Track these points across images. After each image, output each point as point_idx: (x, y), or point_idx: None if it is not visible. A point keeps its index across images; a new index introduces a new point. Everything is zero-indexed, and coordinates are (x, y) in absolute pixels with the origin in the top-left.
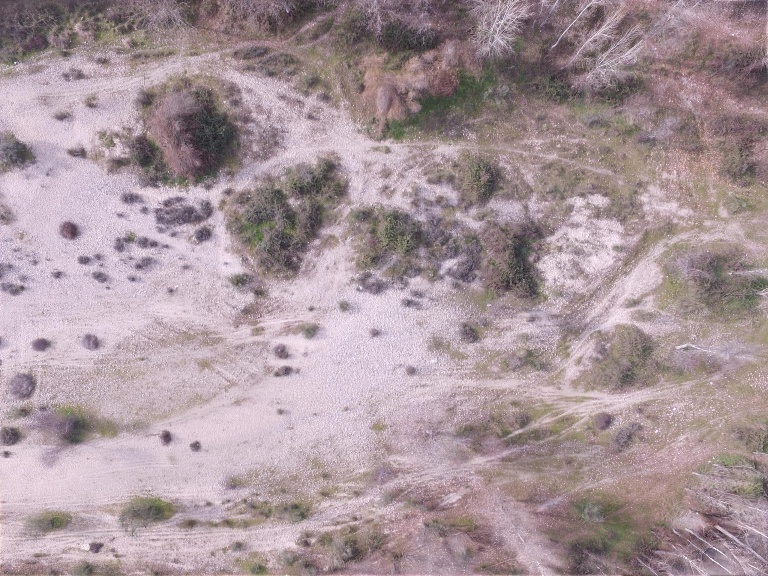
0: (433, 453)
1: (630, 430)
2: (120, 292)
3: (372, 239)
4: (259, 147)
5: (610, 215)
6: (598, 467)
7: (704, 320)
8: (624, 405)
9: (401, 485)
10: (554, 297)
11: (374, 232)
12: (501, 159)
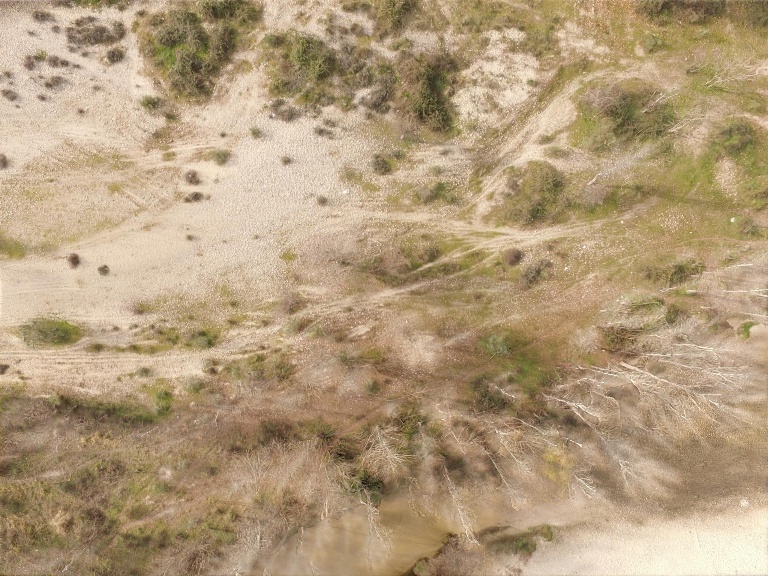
0: (342, 284)
1: (539, 266)
2: (30, 111)
3: (284, 63)
4: None
5: (526, 49)
6: (507, 303)
7: (617, 158)
8: (534, 242)
9: (310, 315)
10: (468, 131)
11: (287, 57)
12: None
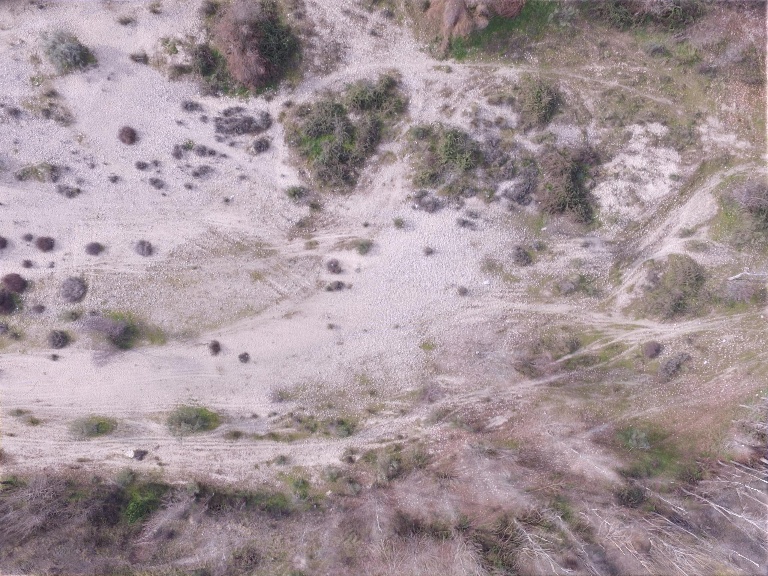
0: (481, 375)
1: (679, 359)
2: (176, 199)
3: (431, 156)
4: (321, 61)
5: (668, 144)
6: (646, 396)
7: (757, 253)
8: (674, 335)
9: (448, 405)
10: (609, 224)
11: (433, 150)
12: (562, 84)
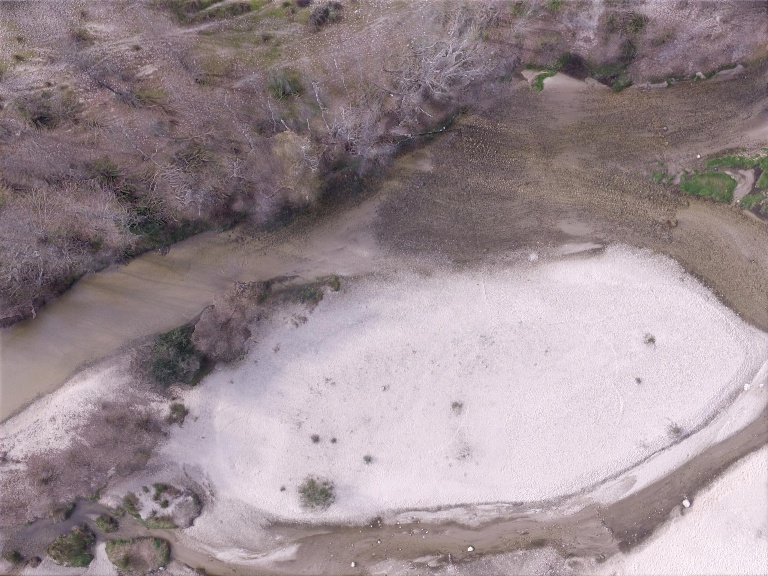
0: (130, 22)
1: (328, 6)
2: None
3: None
4: None
5: None
6: (296, 45)
7: None
8: None
9: (97, 53)
10: None
11: None
12: None
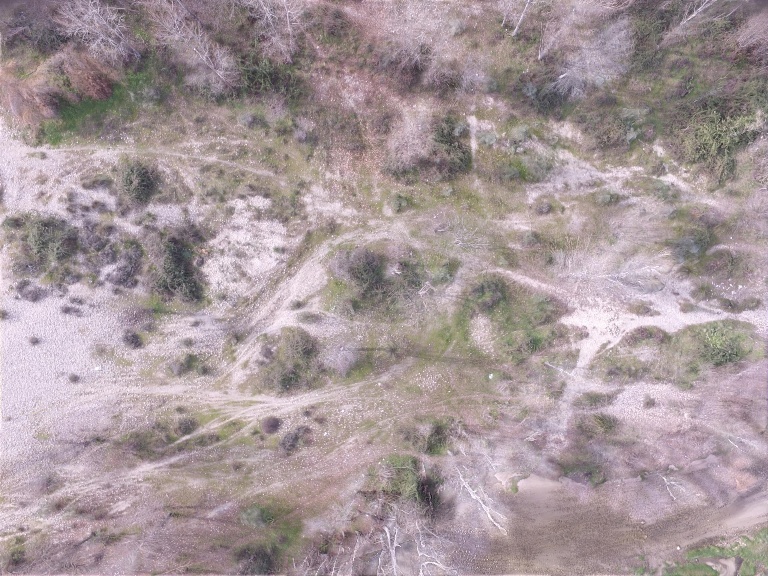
0: (100, 461)
1: (297, 433)
2: None
3: (23, 247)
4: None
5: (271, 217)
6: (268, 471)
7: (370, 321)
8: (292, 408)
9: (68, 494)
10: (218, 301)
11: None
12: (160, 162)
